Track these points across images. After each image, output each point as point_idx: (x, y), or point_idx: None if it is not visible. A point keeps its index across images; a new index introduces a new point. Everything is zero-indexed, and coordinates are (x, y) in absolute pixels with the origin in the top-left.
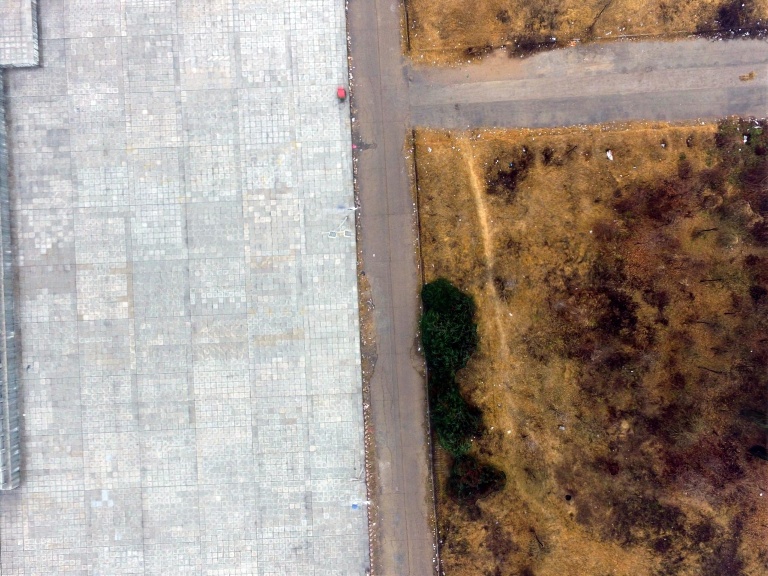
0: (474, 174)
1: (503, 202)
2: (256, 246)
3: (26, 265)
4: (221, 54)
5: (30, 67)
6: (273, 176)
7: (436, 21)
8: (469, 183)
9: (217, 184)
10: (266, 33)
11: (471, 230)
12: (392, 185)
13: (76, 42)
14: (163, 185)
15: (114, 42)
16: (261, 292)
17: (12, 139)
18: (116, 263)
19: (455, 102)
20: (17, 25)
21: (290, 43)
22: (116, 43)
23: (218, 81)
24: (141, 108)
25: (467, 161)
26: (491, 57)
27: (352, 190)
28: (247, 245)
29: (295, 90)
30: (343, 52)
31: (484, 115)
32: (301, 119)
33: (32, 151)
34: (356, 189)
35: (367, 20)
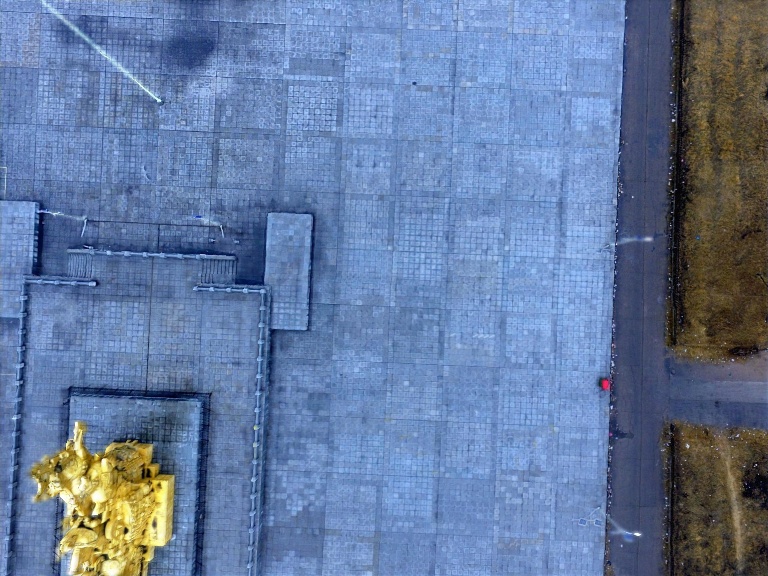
0: (731, 475)
1: (759, 507)
2: (505, 527)
3: (276, 525)
4: (486, 332)
5: (298, 330)
6: (528, 458)
7: (703, 318)
8: (726, 484)
9: (472, 461)
10: (533, 315)
11: (724, 532)
12: (646, 477)
13: (345, 309)
14: (418, 457)
15: (382, 312)
16: (506, 574)
17: (273, 399)
18: (365, 531)
19: (715, 399)
20: (293, 292)
21: (556, 327)
22: (384, 313)
23: (481, 359)
24: (403, 379)
25: (725, 461)
26: (755, 358)
27: (606, 479)
28: (496, 525)
29: (557, 374)
30: (608, 341)
31: (744, 415)
32: (561, 404)
33: (292, 412)
34: (609, 477)
35: (633, 309)
